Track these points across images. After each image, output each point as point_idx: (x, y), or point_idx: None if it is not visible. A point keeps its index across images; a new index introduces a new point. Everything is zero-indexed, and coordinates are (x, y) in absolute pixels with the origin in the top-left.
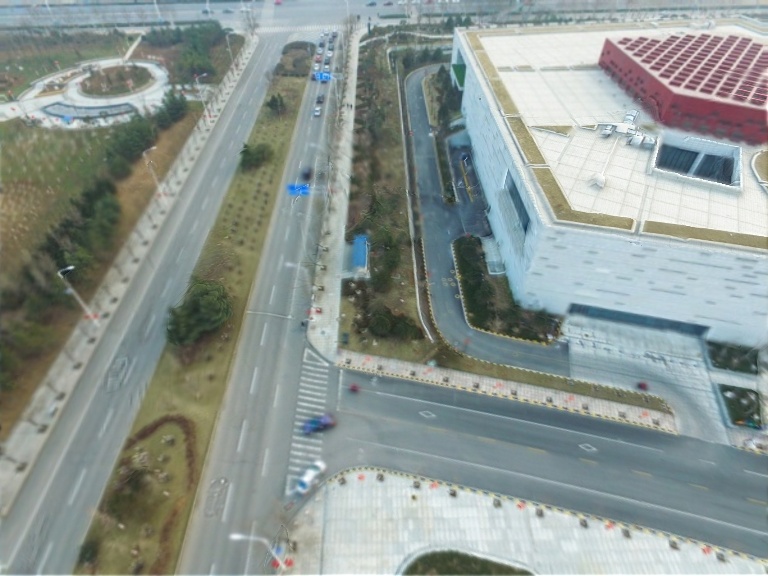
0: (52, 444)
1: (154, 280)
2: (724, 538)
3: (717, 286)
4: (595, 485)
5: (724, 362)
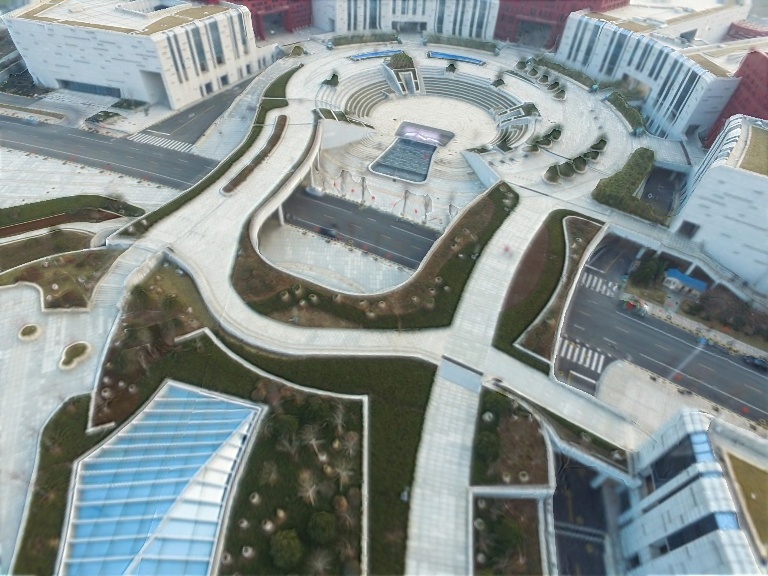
0: None
1: None
2: (22, 148)
3: (95, 54)
4: None
5: (119, 105)
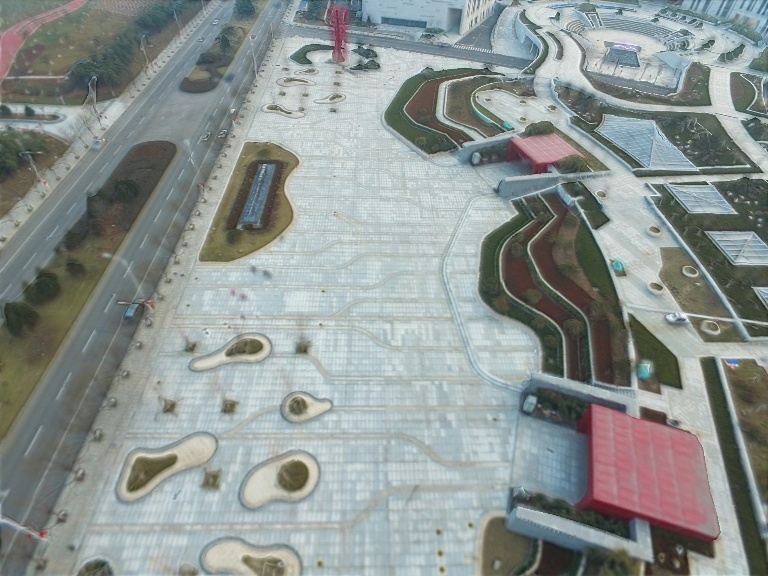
0: None
1: (223, 9)
2: None
3: None
4: None
5: (429, 31)
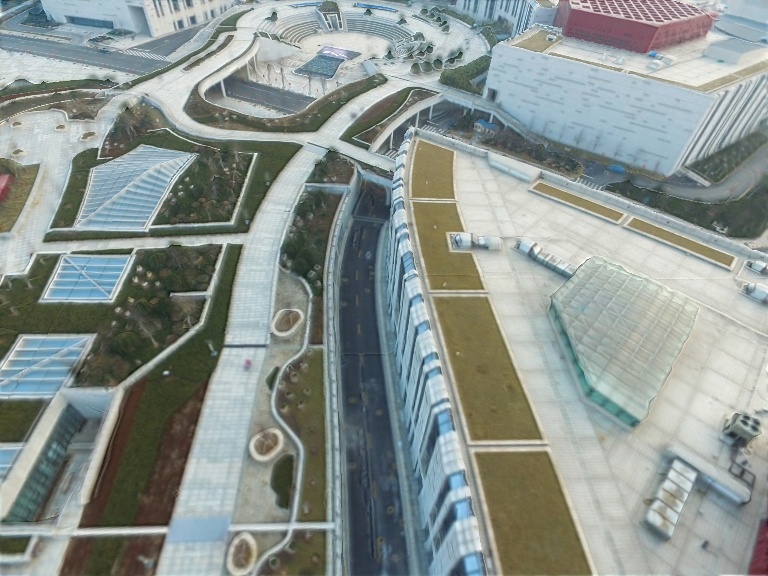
0: None
1: None
2: (43, 55)
3: None
4: (11, 46)
5: (112, 33)
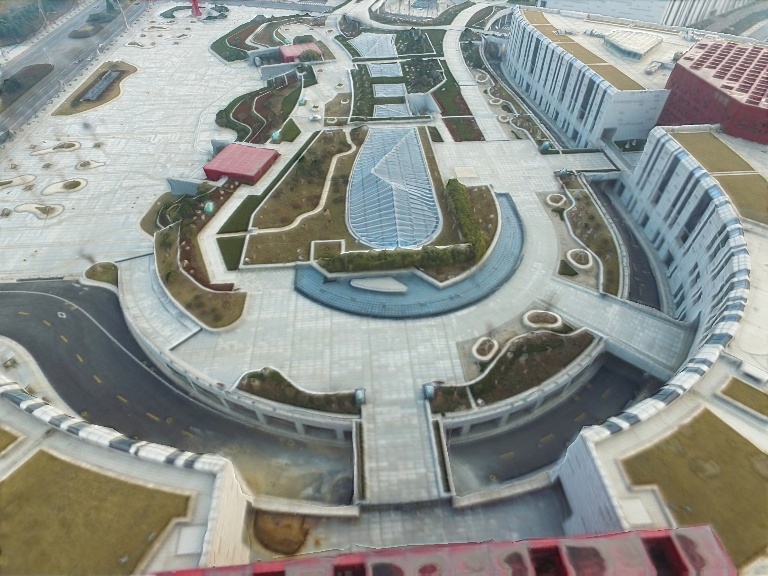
0: (97, 1)
1: None
2: (252, 6)
3: None
4: (228, 3)
5: None
